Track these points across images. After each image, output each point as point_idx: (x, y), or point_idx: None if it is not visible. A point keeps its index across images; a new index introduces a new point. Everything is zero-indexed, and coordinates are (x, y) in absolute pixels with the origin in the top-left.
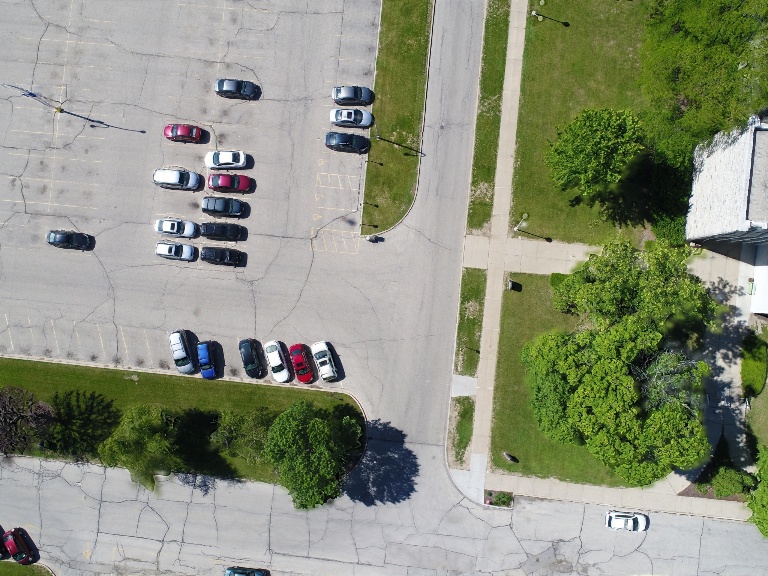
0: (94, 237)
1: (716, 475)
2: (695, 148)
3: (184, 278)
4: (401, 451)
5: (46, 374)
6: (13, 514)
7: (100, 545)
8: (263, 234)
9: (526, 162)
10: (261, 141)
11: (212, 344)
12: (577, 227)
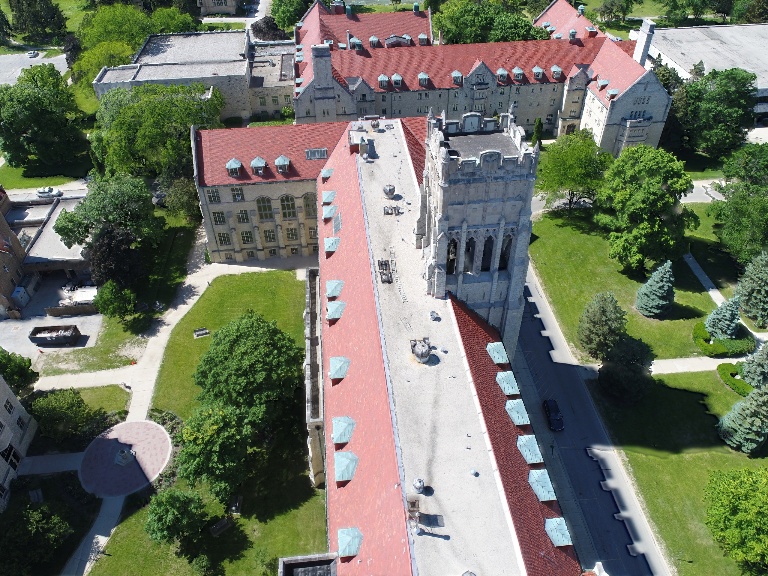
0: None
1: None
2: None
3: None
4: None
5: None
6: None
7: None
8: None
9: None
10: None
11: None
12: None
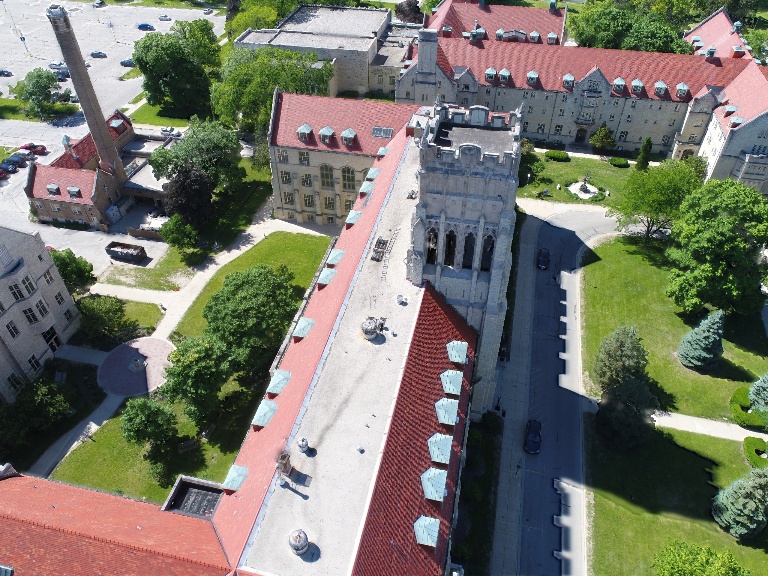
0: None
1: None
2: None
3: None
4: None
5: None
6: None
7: None
8: None
9: None
10: None
11: None
12: None
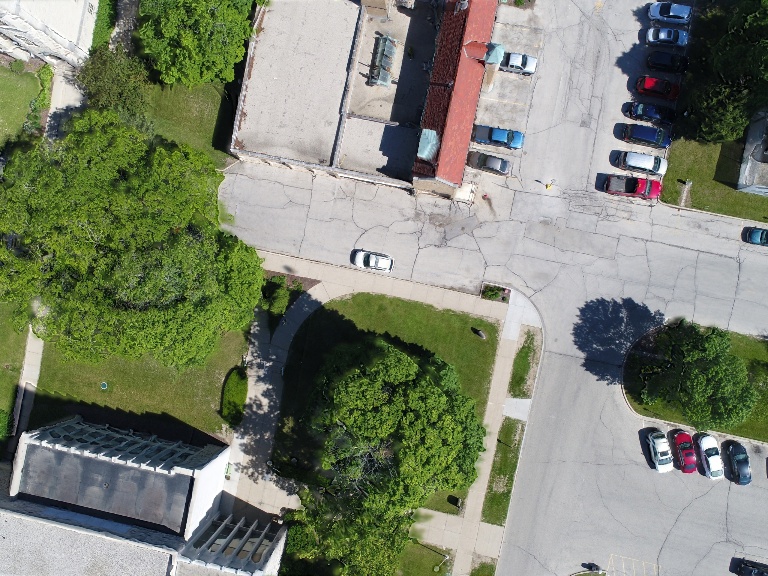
0: None
1: None
2: None
3: None
4: (589, 350)
5: None
6: None
7: None
8: None
9: None
10: None
11: None
12: None
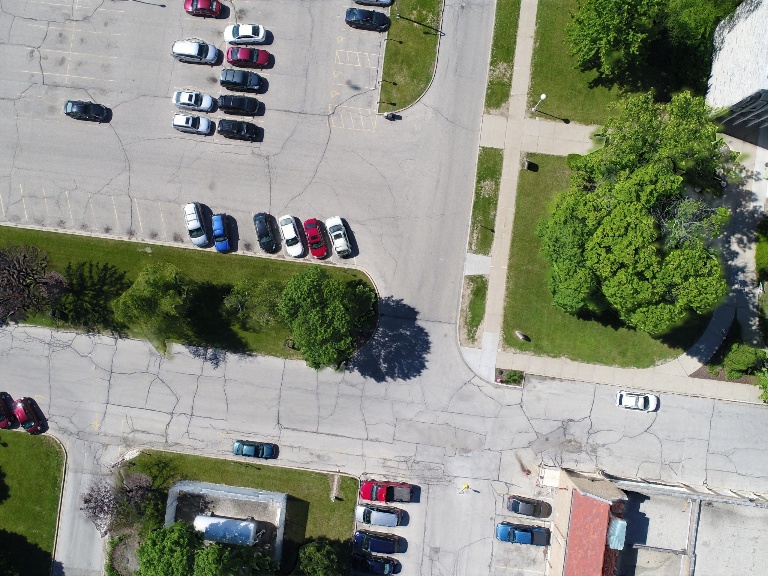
0: (111, 109)
1: (729, 353)
2: (715, 29)
3: (200, 152)
4: (413, 328)
5: (59, 244)
6: (23, 384)
7: (109, 416)
8: (280, 110)
9: (545, 43)
10: (281, 17)
11: (227, 217)
12: (595, 109)
